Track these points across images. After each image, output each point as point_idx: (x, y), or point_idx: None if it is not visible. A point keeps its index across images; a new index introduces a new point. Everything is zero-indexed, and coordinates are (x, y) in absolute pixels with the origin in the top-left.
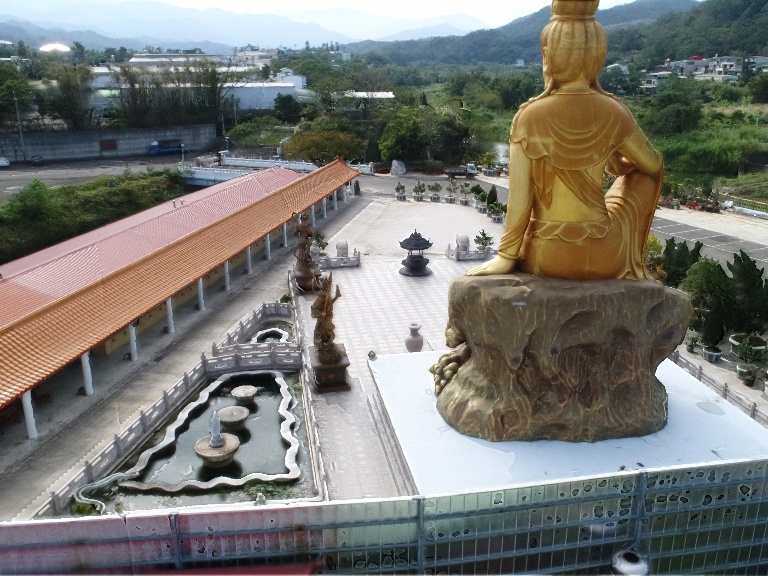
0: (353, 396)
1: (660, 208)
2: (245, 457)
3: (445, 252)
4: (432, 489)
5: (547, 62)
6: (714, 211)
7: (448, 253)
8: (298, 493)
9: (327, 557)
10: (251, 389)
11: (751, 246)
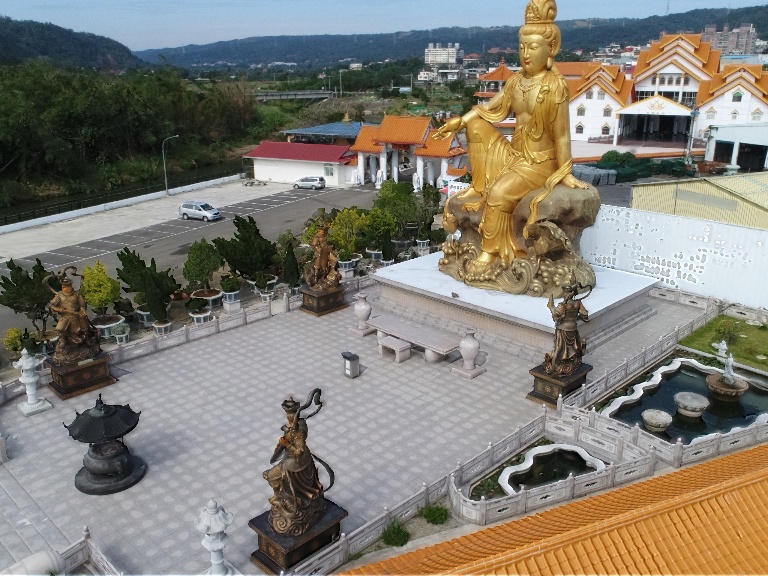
0: None
1: None
2: None
3: None
4: (651, 279)
5: None
6: None
7: None
8: (687, 356)
9: (703, 330)
10: (650, 413)
11: None
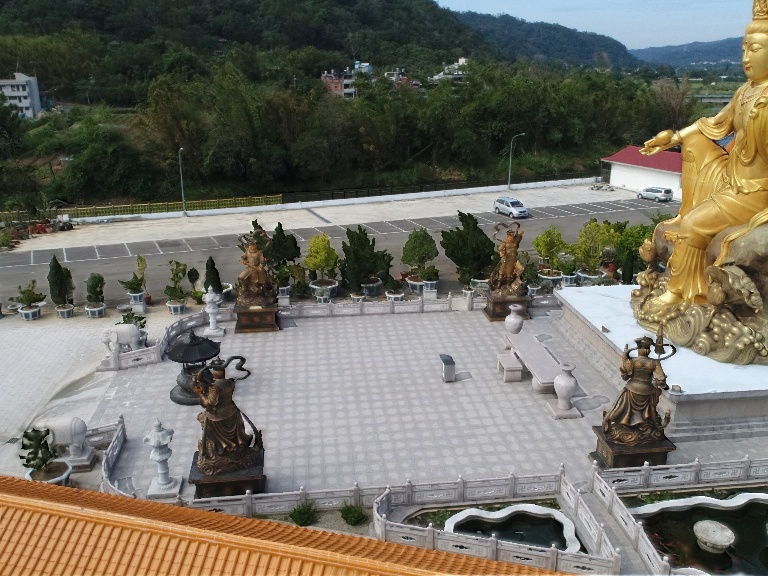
0: None
1: (20, 242)
2: None
3: (98, 367)
4: None
5: None
6: (68, 228)
7: (117, 363)
8: None
9: None
10: (708, 525)
11: (203, 241)
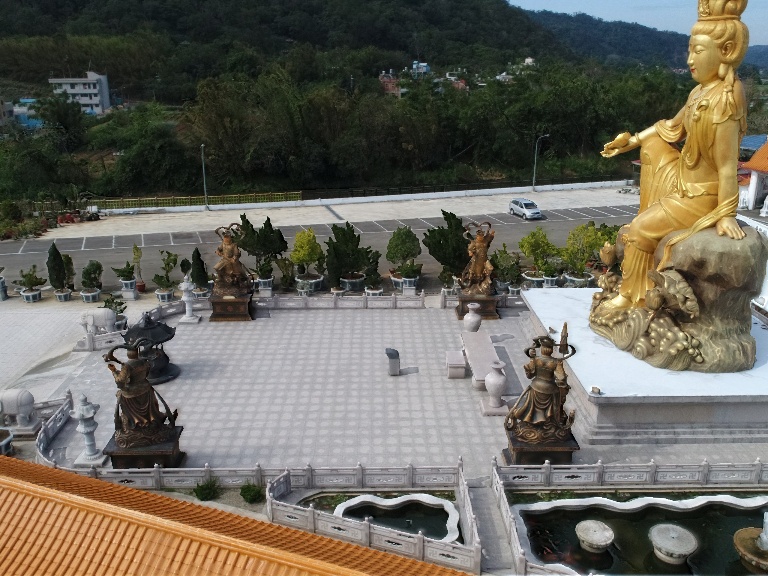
0: (582, 453)
1: (47, 230)
2: (718, 556)
3: (75, 347)
4: None
5: (739, 53)
6: (95, 219)
7: (92, 344)
8: None
9: None
10: (591, 525)
11: (215, 234)
